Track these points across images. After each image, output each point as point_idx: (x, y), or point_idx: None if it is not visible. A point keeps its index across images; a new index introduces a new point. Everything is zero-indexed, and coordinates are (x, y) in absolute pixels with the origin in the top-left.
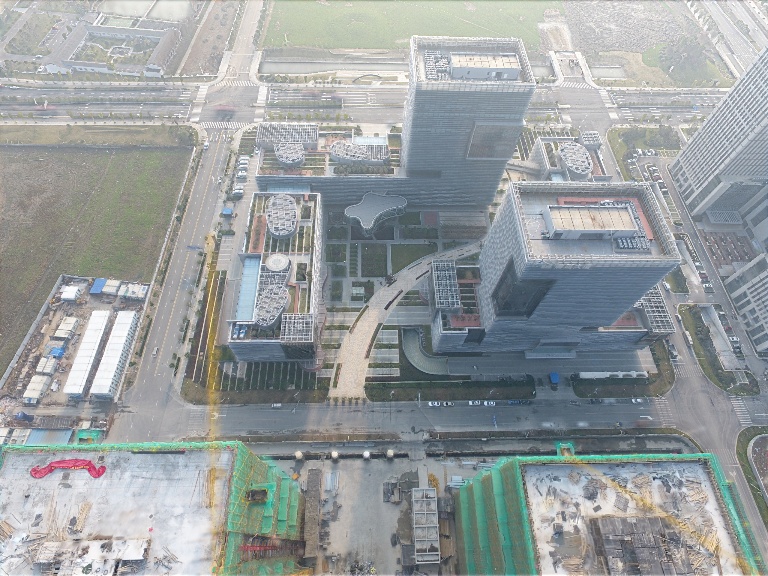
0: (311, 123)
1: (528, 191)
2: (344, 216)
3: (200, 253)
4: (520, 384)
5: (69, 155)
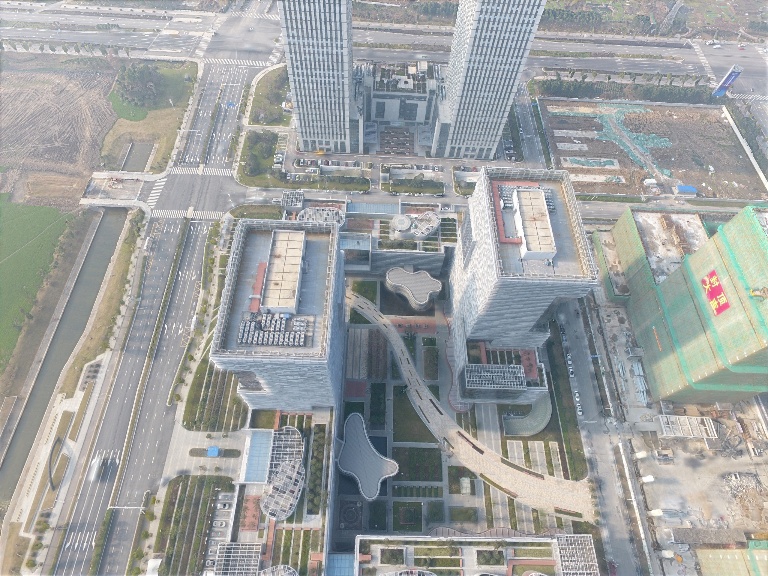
0: (150, 567)
1: None
2: None
3: None
4: None
5: None
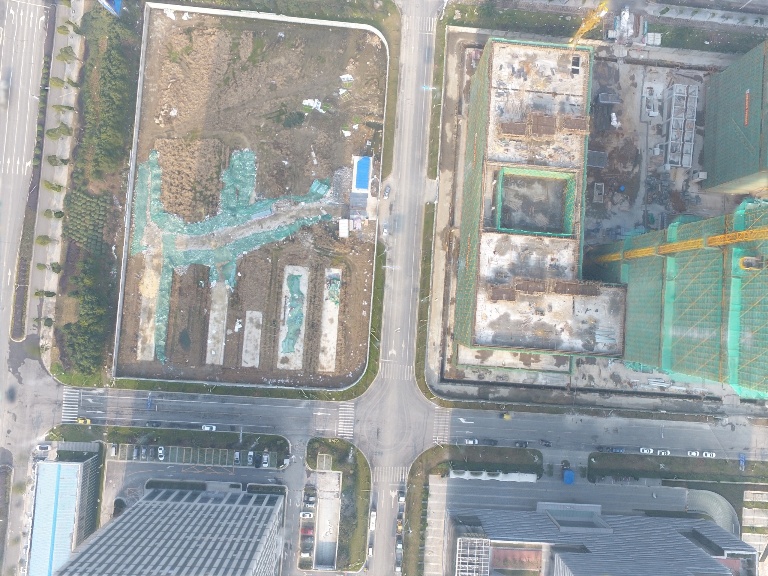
0: None
1: None
2: None
3: None
4: (606, 472)
5: None
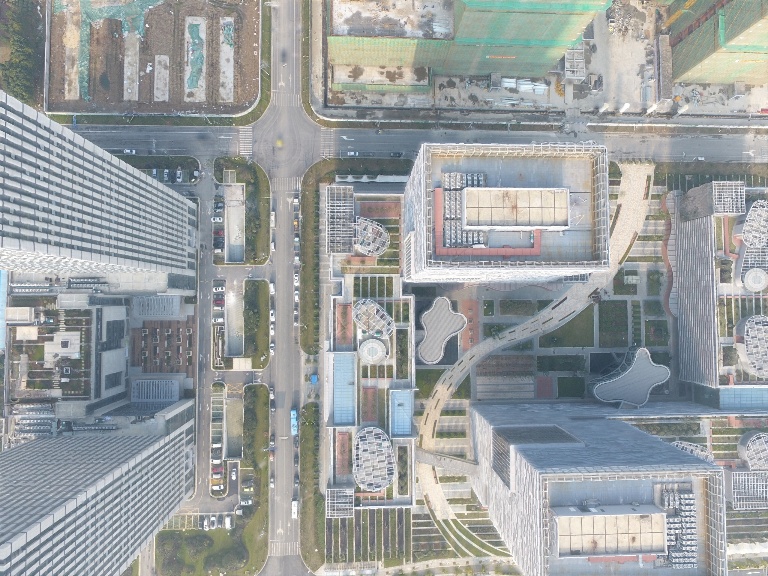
0: None
1: None
2: None
3: None
4: None
5: None
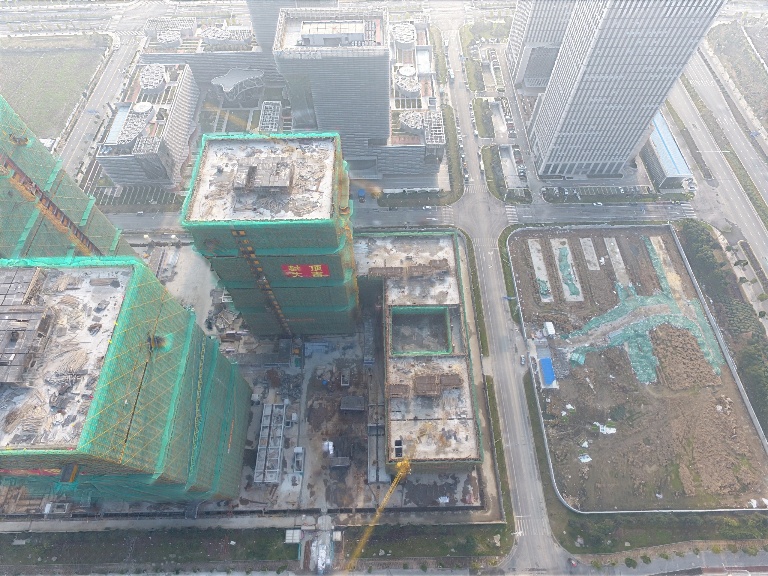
0: None
1: (296, 17)
2: (213, 86)
3: (97, 116)
4: None
5: (8, 57)
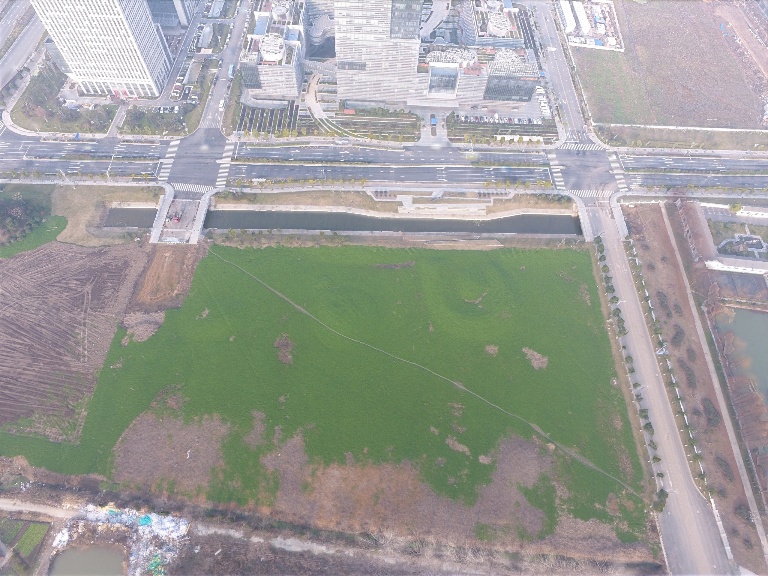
0: (499, 137)
1: None
2: None
3: None
4: None
5: (691, 123)
